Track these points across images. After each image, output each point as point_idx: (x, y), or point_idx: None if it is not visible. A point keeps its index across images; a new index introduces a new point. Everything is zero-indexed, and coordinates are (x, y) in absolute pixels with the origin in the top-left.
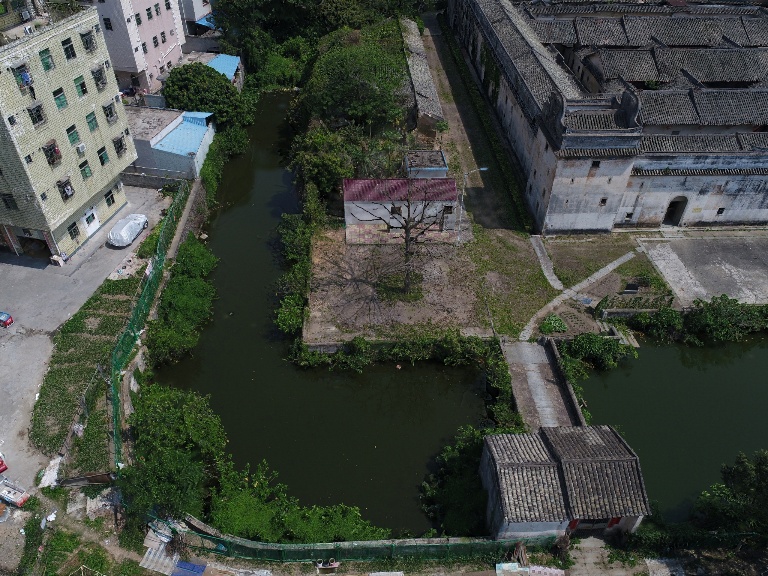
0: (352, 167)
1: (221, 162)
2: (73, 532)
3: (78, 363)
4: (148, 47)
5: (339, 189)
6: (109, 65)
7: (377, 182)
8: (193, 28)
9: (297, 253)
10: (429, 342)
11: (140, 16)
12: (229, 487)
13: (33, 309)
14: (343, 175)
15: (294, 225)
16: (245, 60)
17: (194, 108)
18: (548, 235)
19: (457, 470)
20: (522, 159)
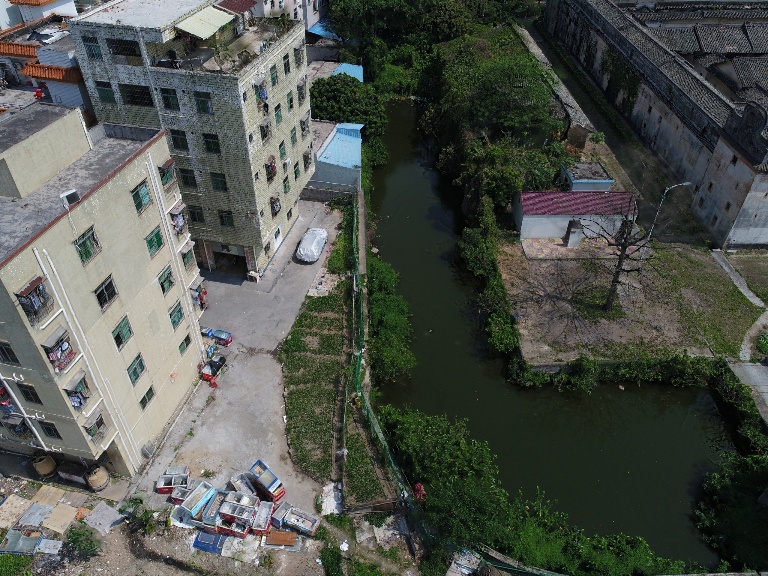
0: (523, 180)
1: (370, 174)
2: (371, 563)
3: (313, 384)
4: None
5: (508, 202)
6: (306, 79)
7: (555, 195)
8: None
9: (482, 268)
10: (654, 362)
11: None
12: (511, 516)
13: (246, 327)
14: (519, 188)
15: (475, 239)
16: (364, 69)
17: (344, 119)
18: (729, 249)
19: (733, 499)
20: (679, 170)
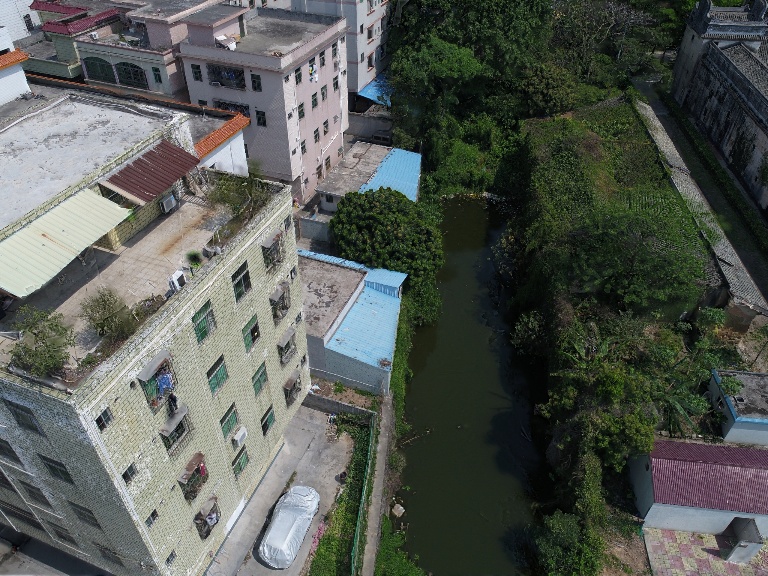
0: None
1: (409, 343)
2: None
3: None
4: (307, 145)
5: None
6: (295, 272)
7: (712, 469)
8: (351, 98)
9: None
10: None
11: (303, 106)
12: None
13: None
14: None
15: None
16: (424, 155)
17: (379, 263)
18: None
19: None
20: None
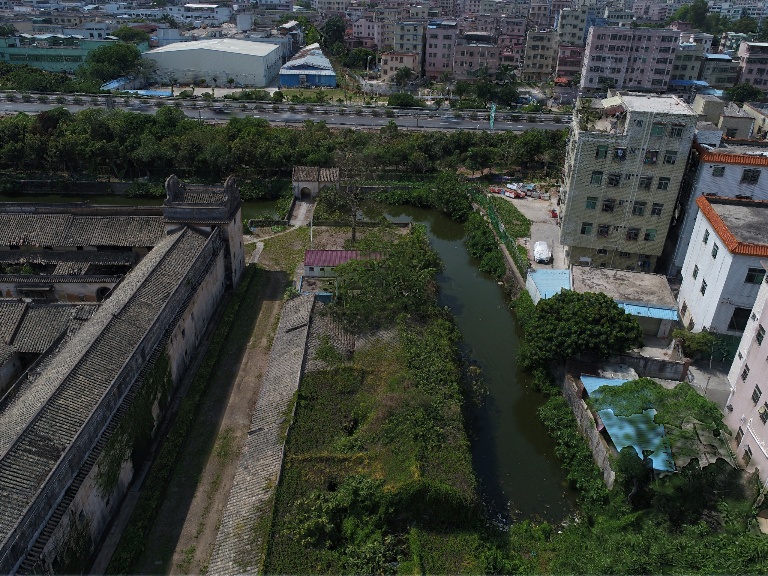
0: None
1: None
2: None
3: None
4: None
5: None
6: None
7: None
8: None
9: None
10: None
11: None
12: None
13: (554, 228)
14: None
15: None
16: None
17: None
18: None
19: None
20: None
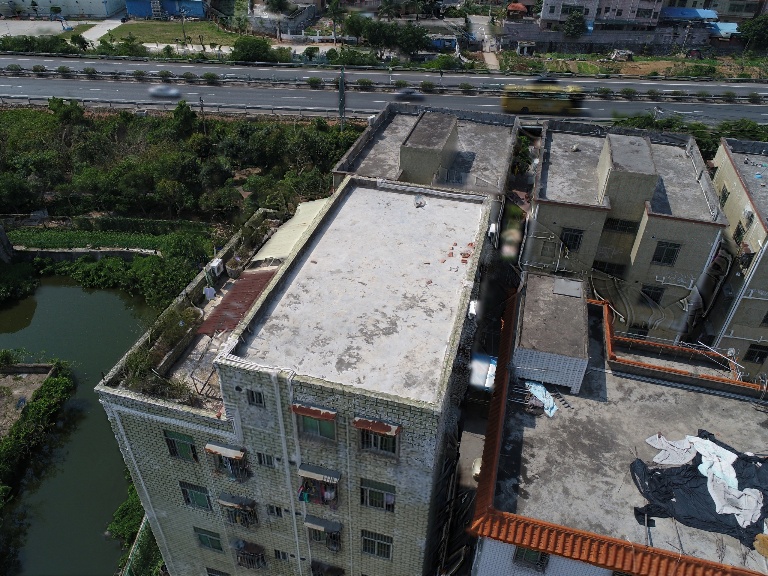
0: None
1: None
2: None
3: None
4: None
5: None
6: None
7: None
8: None
9: None
10: None
11: None
12: None
13: None
14: None
15: None
16: None
17: None
18: None
19: (3, 283)
20: None
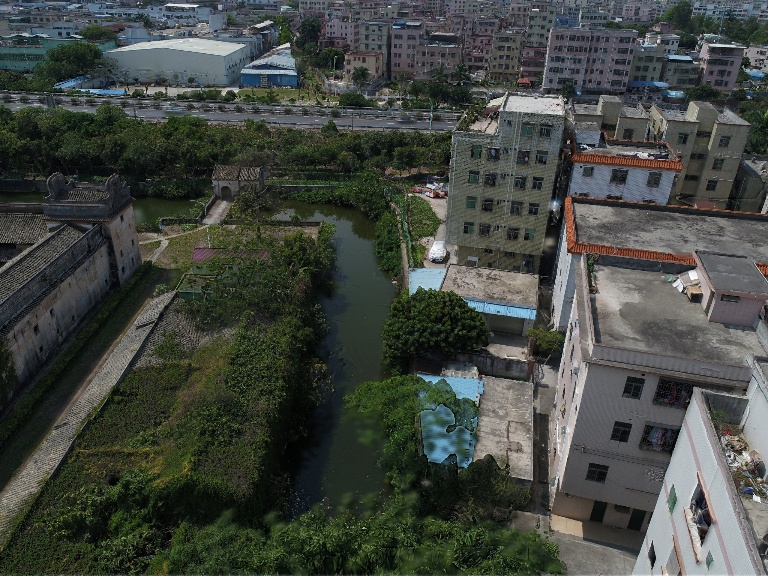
0: None
1: None
2: None
3: None
4: None
5: None
6: None
7: None
8: None
9: None
10: None
11: None
12: None
13: None
14: None
15: None
16: None
17: None
18: None
19: None
20: None
